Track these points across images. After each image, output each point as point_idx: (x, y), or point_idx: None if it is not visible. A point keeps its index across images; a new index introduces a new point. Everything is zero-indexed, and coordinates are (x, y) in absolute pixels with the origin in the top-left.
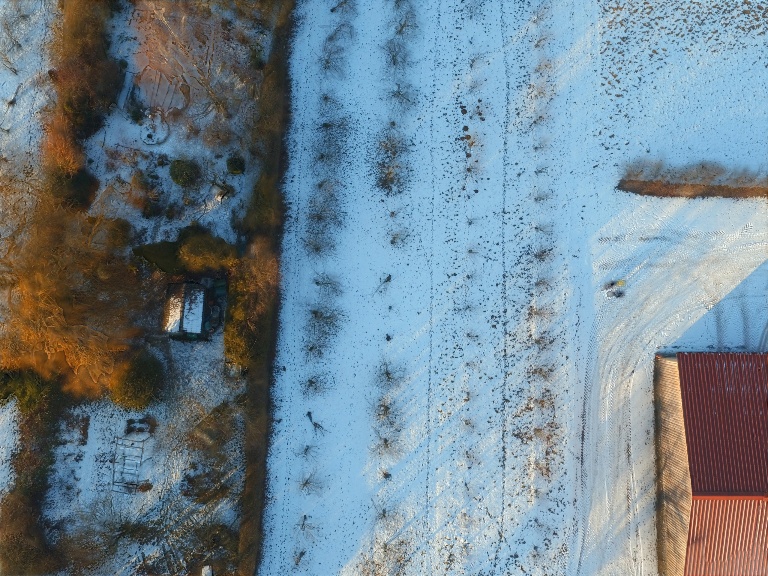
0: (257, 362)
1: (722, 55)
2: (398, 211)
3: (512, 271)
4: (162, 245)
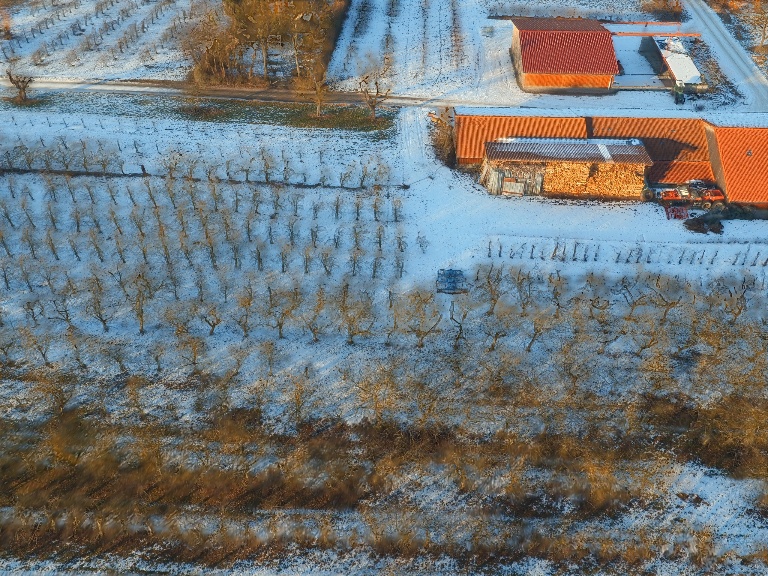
0: (332, 27)
1: (529, 5)
2: None
3: None
4: None
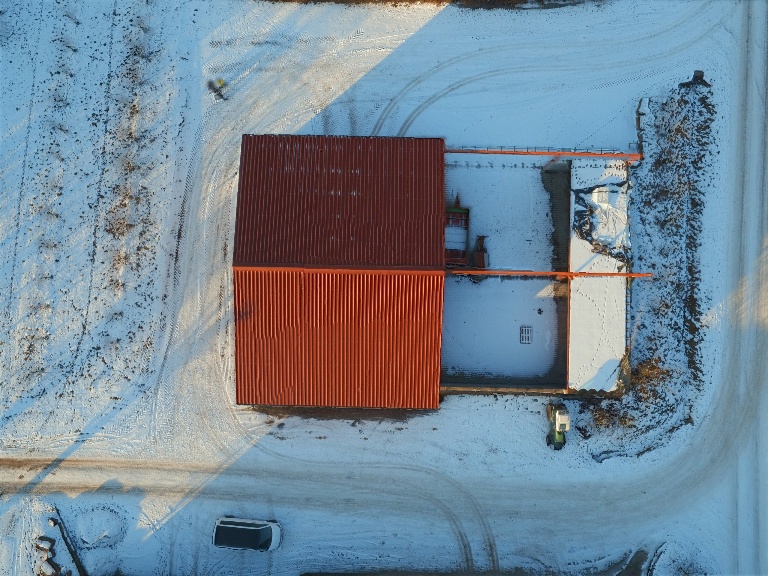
0: None
1: None
2: (5, 10)
3: (117, 71)
4: None
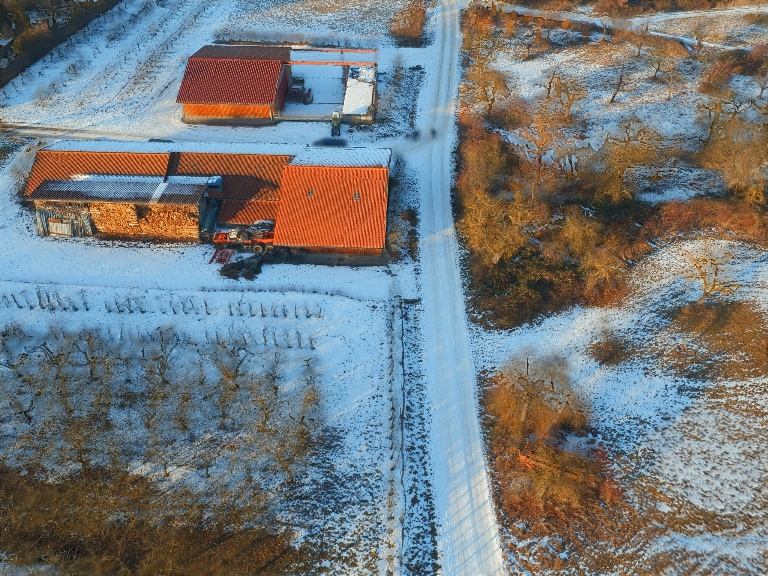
0: (24, 52)
1: None
2: None
3: None
4: (1, 5)
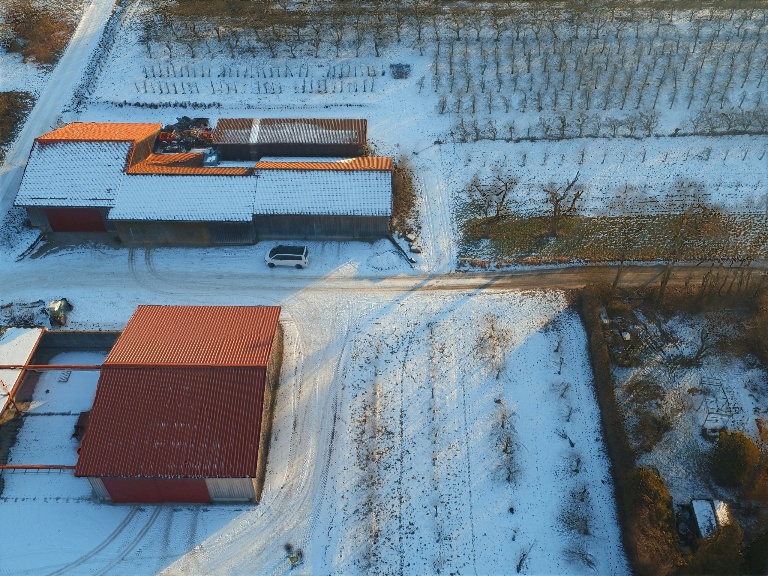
0: None
1: None
2: None
3: None
4: (763, 549)
